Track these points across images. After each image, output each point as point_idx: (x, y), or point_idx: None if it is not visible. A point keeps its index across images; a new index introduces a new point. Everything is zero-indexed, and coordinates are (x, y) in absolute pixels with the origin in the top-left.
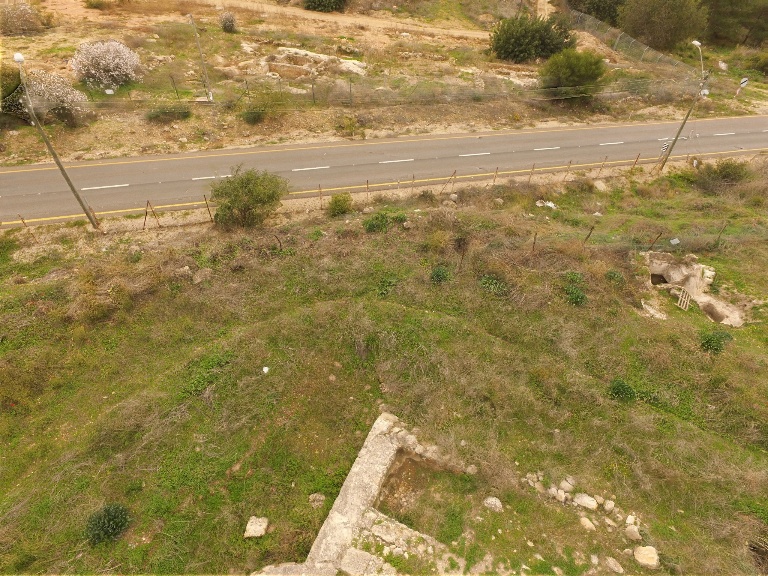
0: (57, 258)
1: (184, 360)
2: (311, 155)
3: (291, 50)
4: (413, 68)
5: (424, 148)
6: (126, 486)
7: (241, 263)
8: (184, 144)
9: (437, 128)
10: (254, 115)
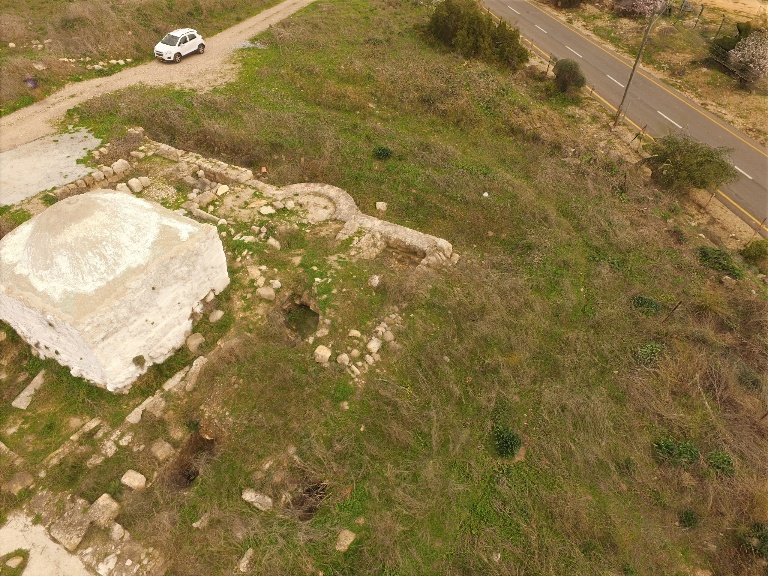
0: (576, 121)
1: None
2: None
3: None
4: None
5: None
6: None
7: None
8: None
9: None
10: None
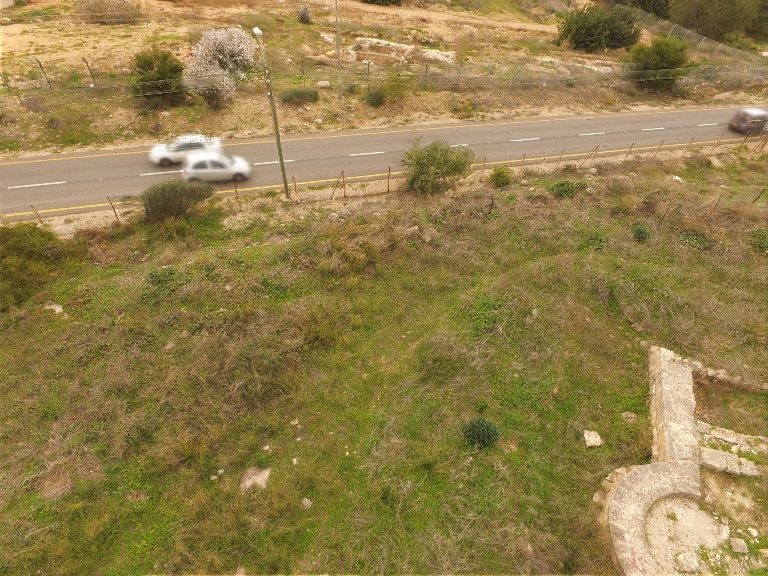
0: (264, 225)
1: (456, 305)
2: (445, 134)
3: (372, 40)
4: (492, 57)
5: (543, 128)
6: (477, 404)
7: (462, 223)
8: (320, 125)
9: (542, 111)
10: (377, 98)
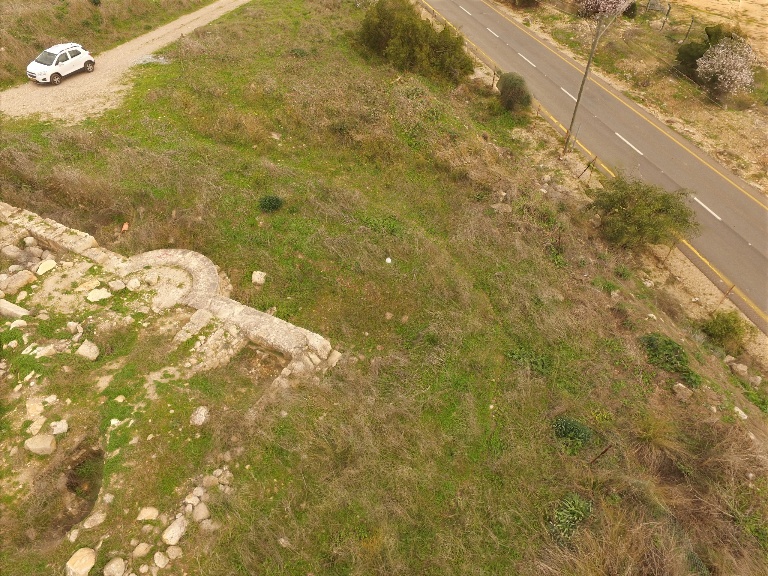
0: (521, 147)
1: None
2: None
3: None
4: None
5: None
6: None
7: None
8: (763, 176)
9: None
10: None
